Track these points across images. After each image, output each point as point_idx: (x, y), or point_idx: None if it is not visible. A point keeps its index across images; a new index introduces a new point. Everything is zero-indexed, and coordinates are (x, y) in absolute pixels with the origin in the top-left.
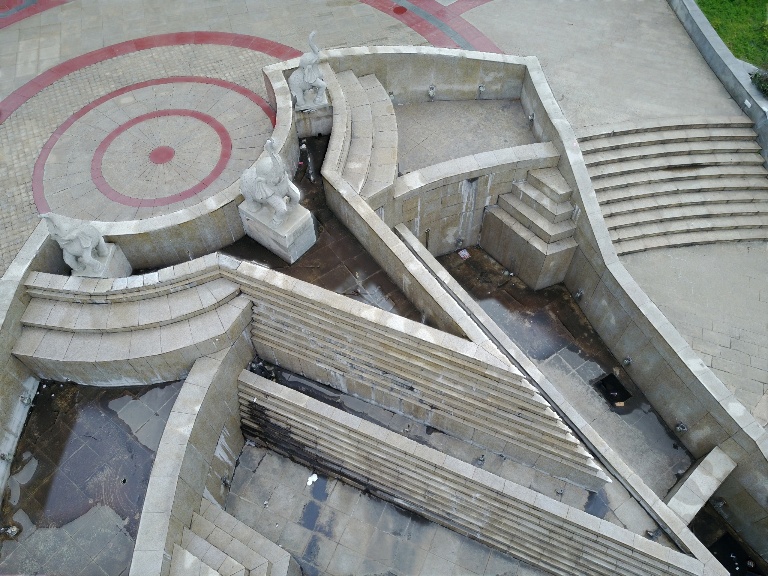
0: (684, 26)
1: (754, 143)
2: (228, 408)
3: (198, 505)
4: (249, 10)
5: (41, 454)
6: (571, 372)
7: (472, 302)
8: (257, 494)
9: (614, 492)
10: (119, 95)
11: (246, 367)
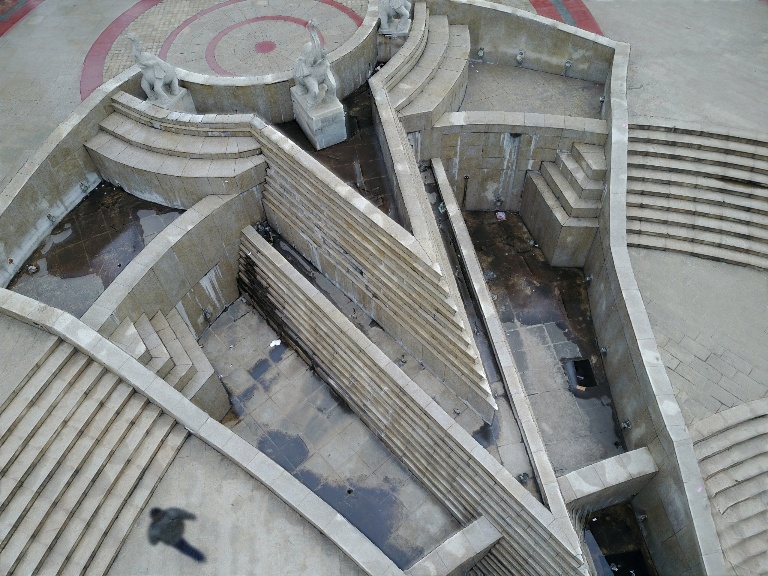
0: None
1: None
2: (226, 251)
3: (167, 309)
4: None
5: (77, 228)
6: (548, 344)
7: (465, 237)
8: (228, 337)
9: (508, 432)
10: None
11: (253, 225)
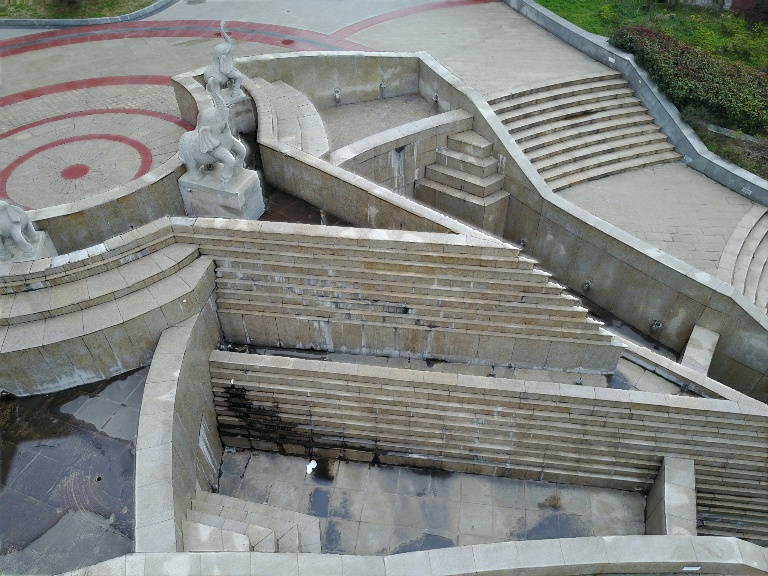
0: (537, 23)
1: (627, 89)
2: (204, 394)
3: (194, 496)
4: (139, 58)
5: None
6: None
7: None
8: (252, 498)
9: (628, 370)
10: (13, 134)
11: (215, 349)
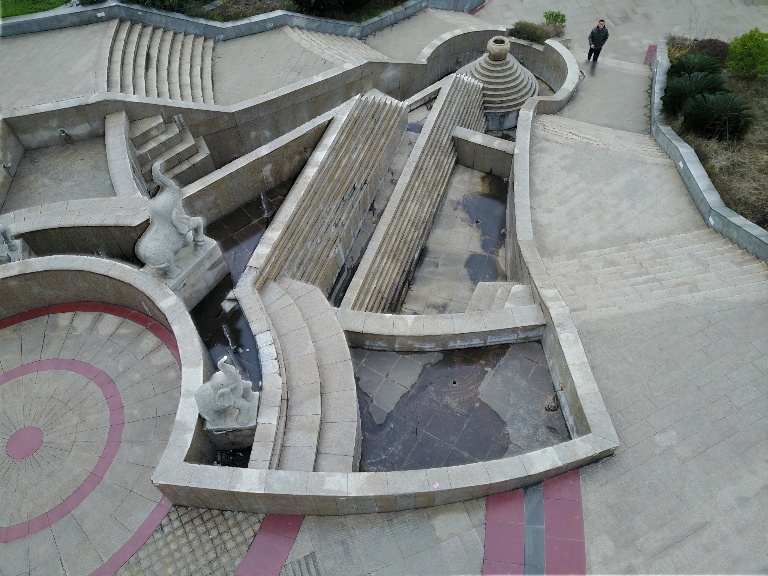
0: None
1: (135, 26)
2: None
3: None
4: None
5: None
6: None
7: None
8: None
9: None
10: None
11: None
